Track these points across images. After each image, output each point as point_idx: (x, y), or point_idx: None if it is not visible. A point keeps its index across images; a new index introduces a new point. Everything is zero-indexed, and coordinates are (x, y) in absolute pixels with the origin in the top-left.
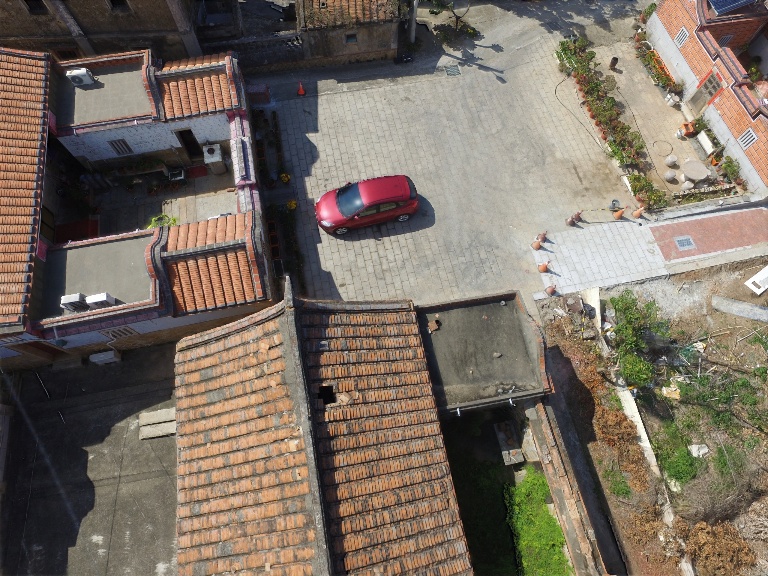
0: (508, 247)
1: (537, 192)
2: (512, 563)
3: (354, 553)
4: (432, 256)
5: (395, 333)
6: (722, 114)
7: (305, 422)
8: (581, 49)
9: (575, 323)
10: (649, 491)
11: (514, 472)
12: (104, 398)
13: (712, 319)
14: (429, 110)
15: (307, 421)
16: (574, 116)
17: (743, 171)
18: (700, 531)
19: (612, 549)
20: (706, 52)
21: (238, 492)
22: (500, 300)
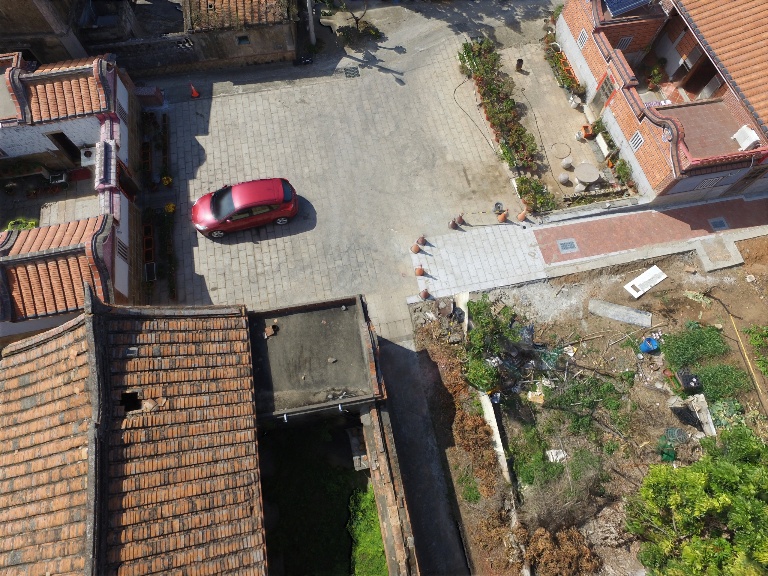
0: (387, 250)
1: (423, 195)
2: (347, 570)
3: (132, 562)
4: (309, 259)
5: (220, 339)
6: (616, 116)
7: (91, 430)
8: (486, 51)
9: (443, 327)
10: (495, 497)
11: (368, 477)
12: None
13: (587, 323)
14: (323, 112)
15: (93, 429)
16: (470, 118)
17: (635, 173)
18: (540, 537)
19: (458, 555)
20: (601, 54)
21: (34, 500)
22: (341, 305)
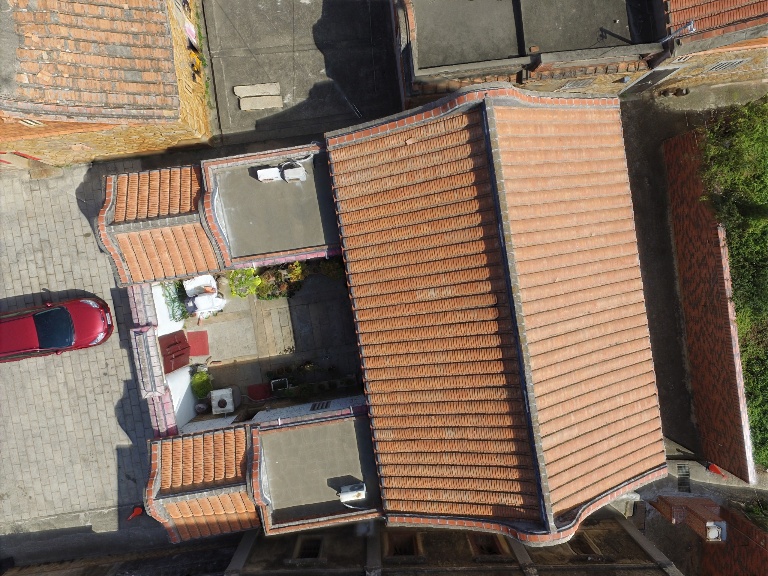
0: None
1: None
2: None
3: None
4: None
5: None
6: None
7: None
8: None
9: None
10: None
11: None
12: (321, 126)
13: None
14: None
15: None
16: None
17: None
18: None
19: None
20: None
21: None
22: None
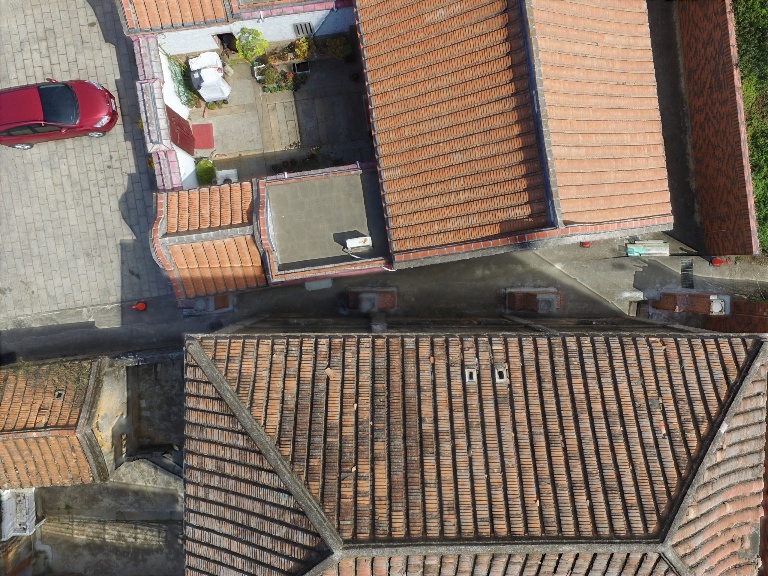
0: None
1: None
2: None
3: None
4: None
5: None
6: None
7: None
8: None
9: None
10: None
11: None
12: None
13: None
14: None
15: None
16: None
17: None
18: None
19: None
20: None
21: None
22: None
